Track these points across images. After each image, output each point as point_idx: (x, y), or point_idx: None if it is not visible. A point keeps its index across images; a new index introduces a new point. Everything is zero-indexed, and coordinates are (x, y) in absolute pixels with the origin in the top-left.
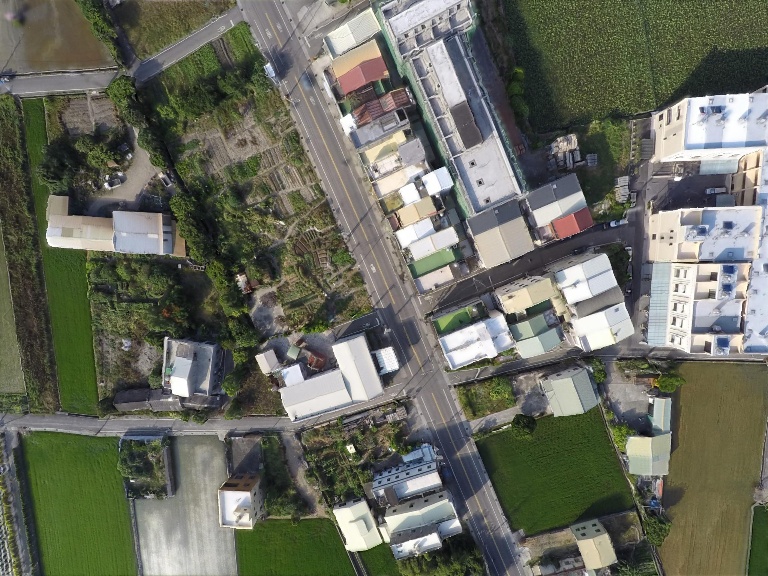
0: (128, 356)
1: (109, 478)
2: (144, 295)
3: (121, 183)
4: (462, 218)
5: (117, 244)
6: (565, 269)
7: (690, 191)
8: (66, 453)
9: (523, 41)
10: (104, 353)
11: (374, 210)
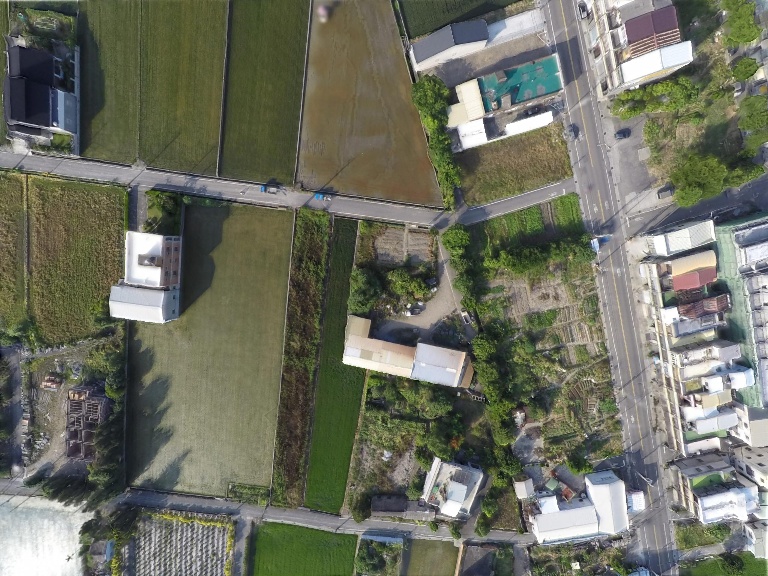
0: (387, 466)
1: (338, 570)
2: (416, 414)
3: (420, 312)
4: None
5: (413, 372)
6: None
7: None
8: (298, 544)
9: None
10: (363, 460)
11: (646, 371)
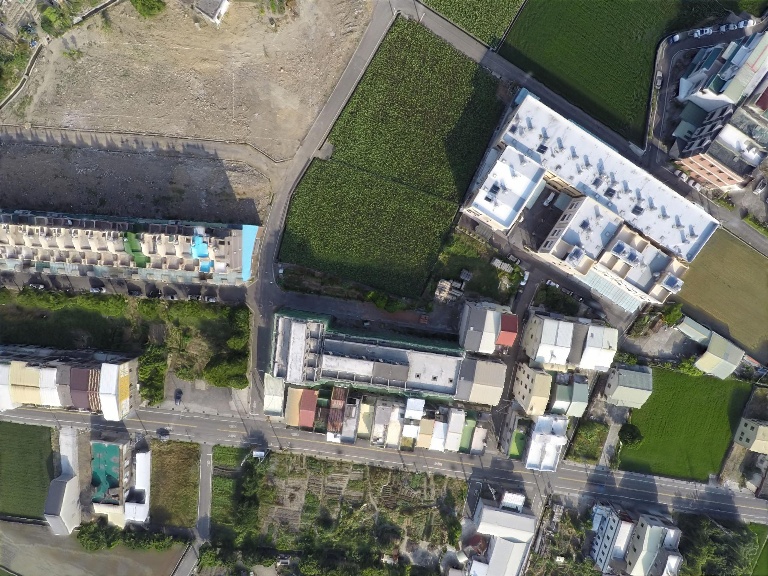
0: None
1: None
2: None
3: None
4: None
5: None
6: (536, 355)
7: (536, 215)
8: None
9: (349, 271)
10: None
11: None
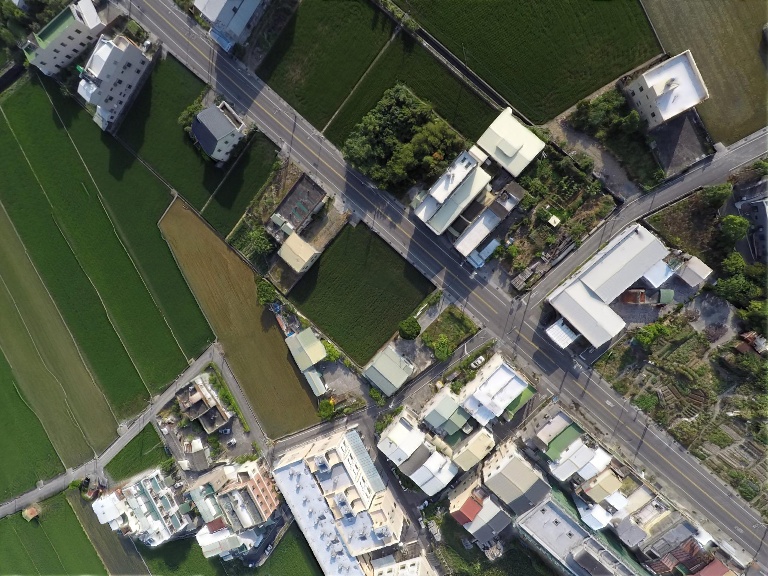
0: None
1: None
2: None
3: None
4: (549, 477)
5: None
6: None
7: None
8: None
9: None
10: None
11: (632, 454)
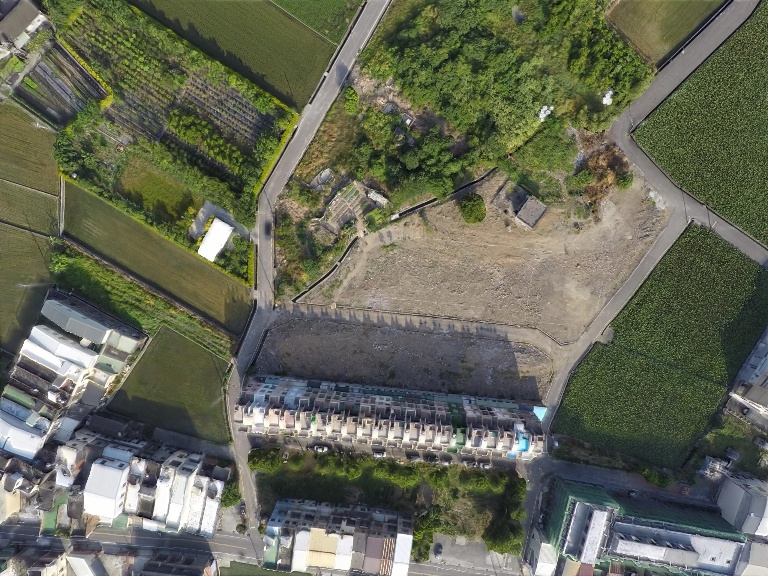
0: None
1: None
2: None
3: None
4: None
5: None
6: None
7: None
8: None
9: (617, 443)
10: None
11: None
